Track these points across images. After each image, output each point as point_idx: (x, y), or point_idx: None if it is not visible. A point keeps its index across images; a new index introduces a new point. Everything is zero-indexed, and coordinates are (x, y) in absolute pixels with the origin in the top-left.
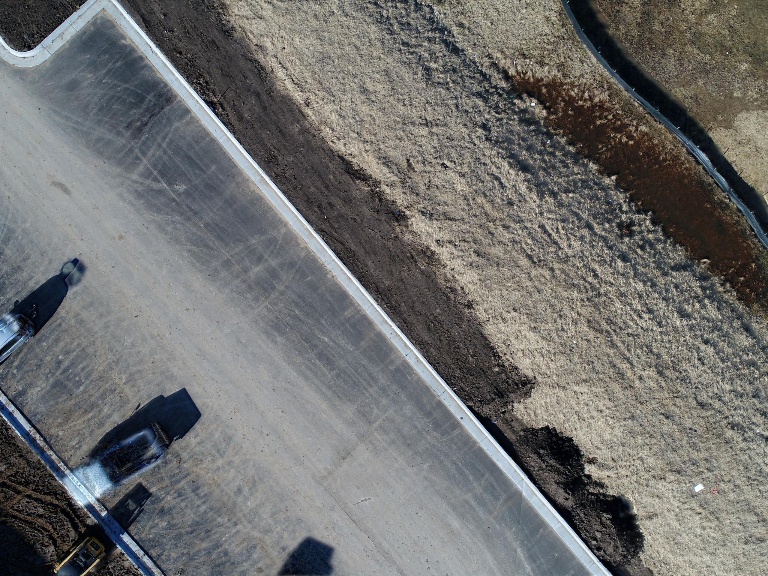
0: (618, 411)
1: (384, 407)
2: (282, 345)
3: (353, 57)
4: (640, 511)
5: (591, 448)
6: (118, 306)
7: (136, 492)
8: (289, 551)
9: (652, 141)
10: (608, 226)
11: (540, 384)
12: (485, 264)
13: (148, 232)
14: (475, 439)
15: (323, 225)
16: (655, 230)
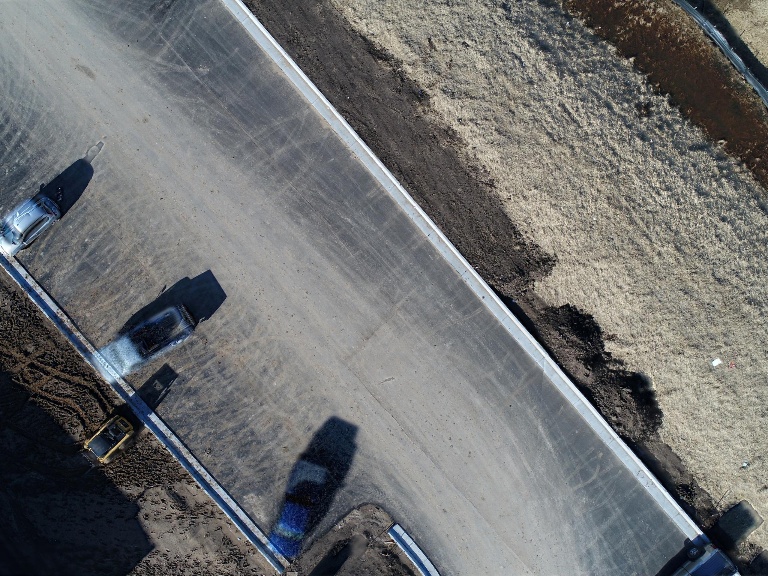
0: (637, 287)
1: (407, 287)
2: (306, 226)
3: None
4: (659, 387)
5: (611, 325)
6: (143, 189)
7: (163, 373)
8: (314, 431)
9: (669, 23)
10: (627, 106)
11: (561, 261)
12: (506, 142)
13: (172, 115)
14: (497, 318)
15: (346, 106)
16: (673, 111)
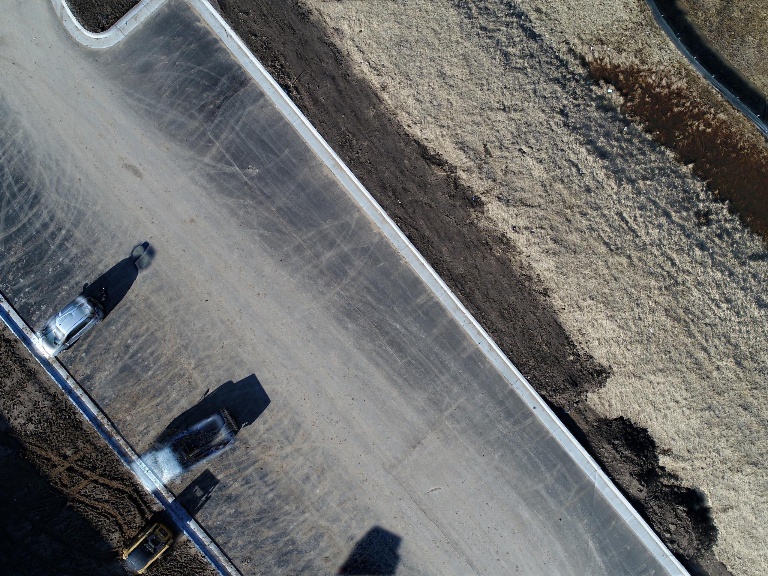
0: (695, 402)
1: (456, 395)
2: (353, 331)
3: (431, 41)
4: (715, 504)
5: (666, 439)
6: (188, 290)
7: (204, 479)
8: (357, 540)
9: (730, 129)
10: (685, 214)
11: (615, 374)
12: (562, 251)
13: (220, 216)
14: (548, 429)
15: (397, 210)
16: (732, 219)
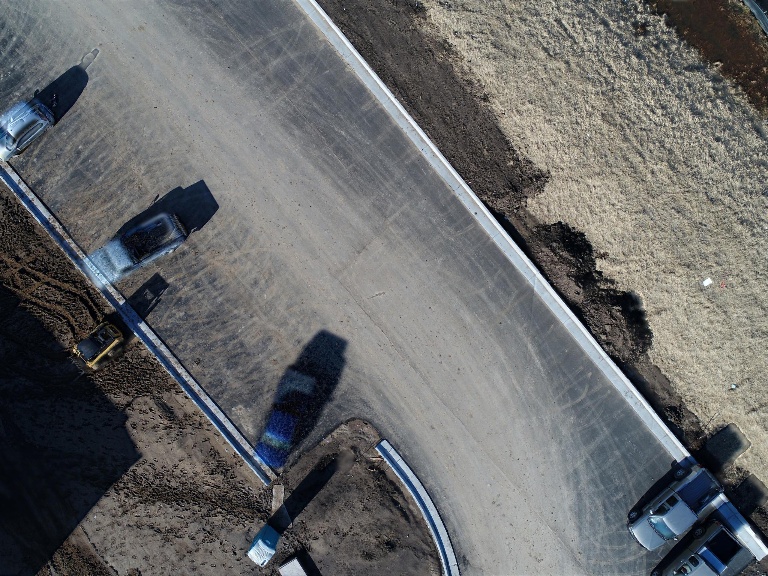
0: (630, 205)
1: (399, 202)
2: (300, 138)
3: None
4: (649, 307)
5: (602, 243)
6: (138, 97)
7: (154, 282)
8: (304, 344)
9: None
10: (623, 24)
11: (554, 178)
12: (502, 56)
13: (168, 23)
14: (489, 234)
15: (342, 17)
16: (669, 31)
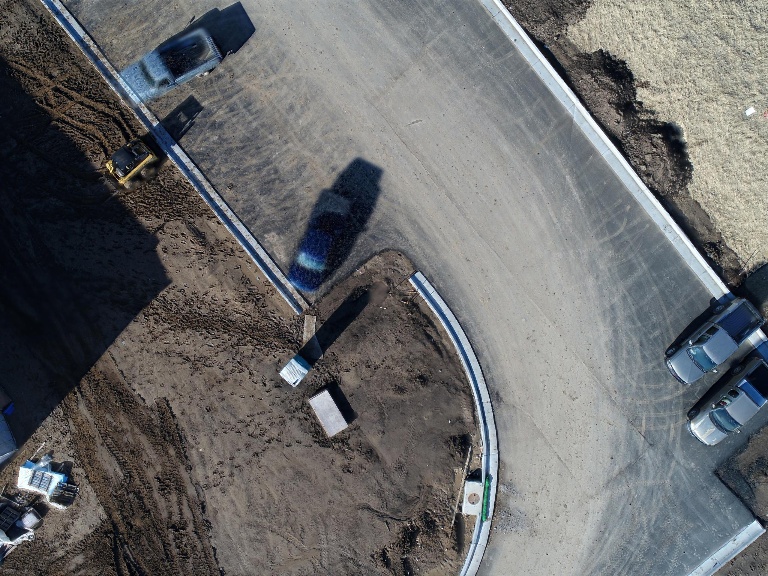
0: (672, 31)
1: (438, 27)
2: None
3: None
4: (690, 138)
5: (644, 71)
6: None
7: (188, 104)
8: (339, 171)
9: None
10: None
11: (595, 3)
12: None
13: None
14: (528, 62)
15: None
16: None
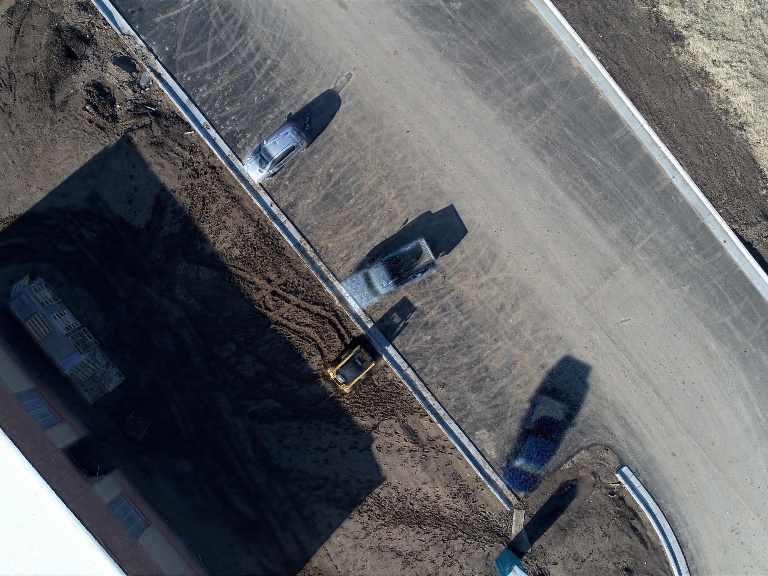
0: None
1: (648, 229)
2: (551, 164)
3: None
4: None
5: None
6: (390, 121)
7: (402, 306)
8: (548, 369)
9: None
10: None
11: None
12: (760, 85)
13: (422, 48)
14: (737, 263)
15: (598, 44)
16: None
